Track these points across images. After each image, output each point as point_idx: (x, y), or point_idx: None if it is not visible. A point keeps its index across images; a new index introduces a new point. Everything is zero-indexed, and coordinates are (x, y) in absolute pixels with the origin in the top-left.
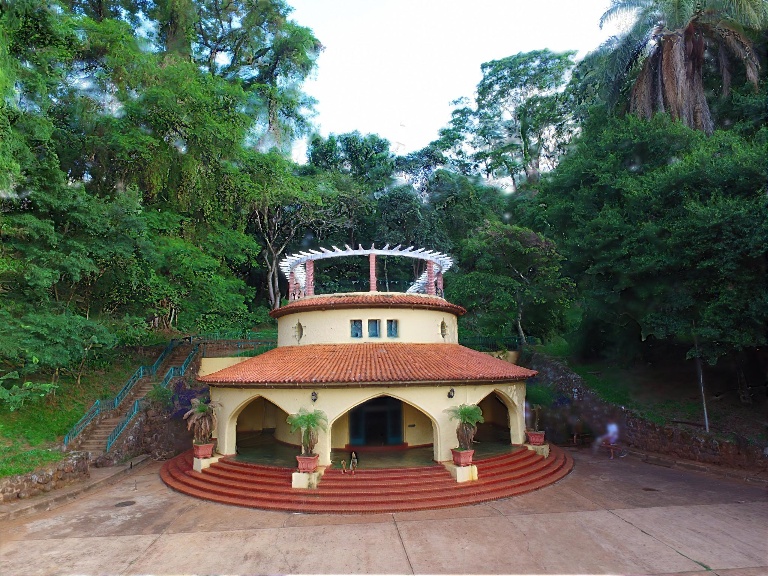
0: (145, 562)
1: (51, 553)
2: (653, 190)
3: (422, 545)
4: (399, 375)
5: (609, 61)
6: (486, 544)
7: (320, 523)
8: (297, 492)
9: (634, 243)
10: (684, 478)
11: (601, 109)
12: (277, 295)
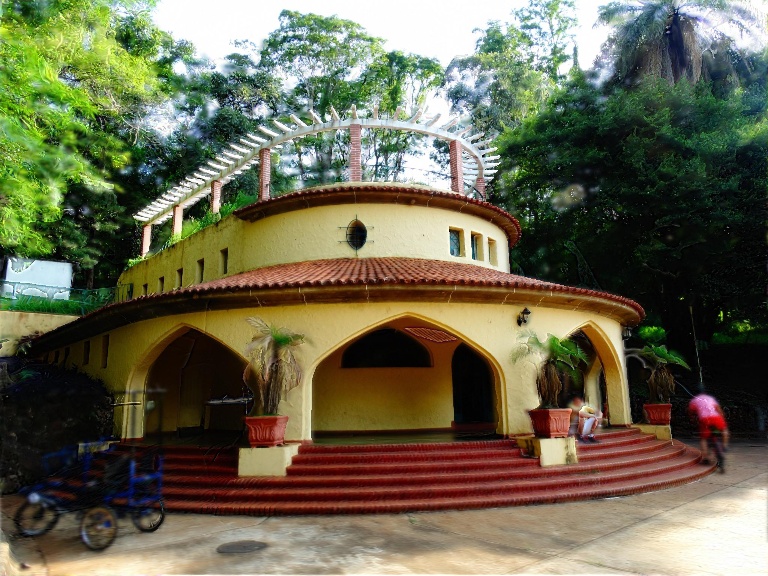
0: None
1: None
2: (732, 147)
3: None
4: None
5: (647, 19)
6: None
7: (682, 499)
8: (567, 469)
9: (717, 196)
10: (733, 441)
11: (590, 73)
12: None
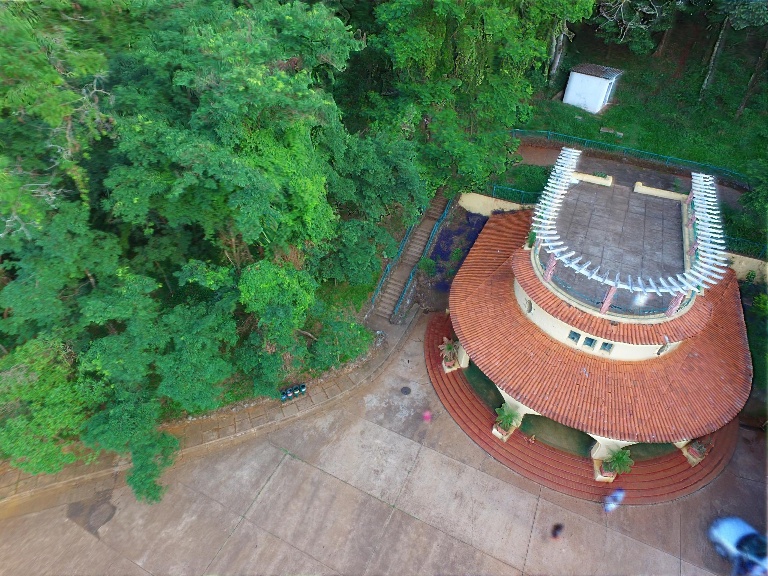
0: (414, 475)
1: (378, 442)
2: None
3: (542, 533)
4: (580, 423)
5: None
6: (576, 553)
7: (499, 476)
8: (493, 440)
9: None
10: None
11: None
12: (558, 52)
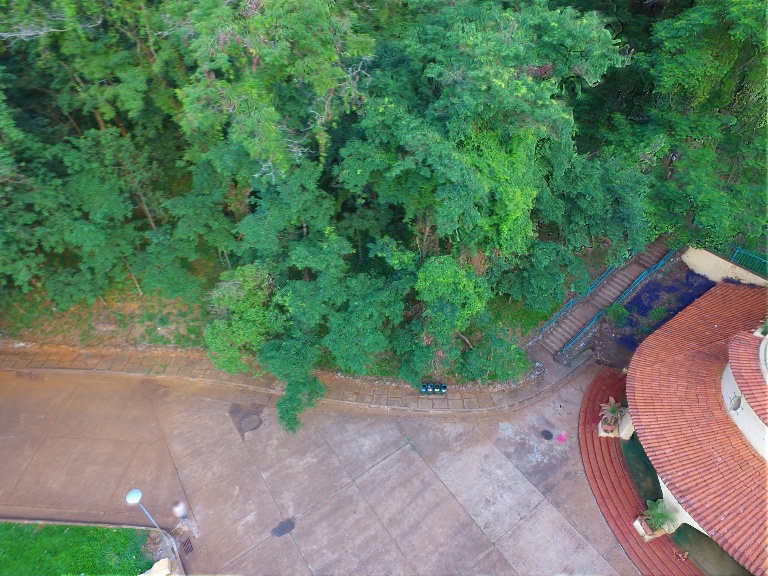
0: (526, 524)
1: (499, 473)
2: None
3: None
4: (760, 569)
5: None
6: None
7: (624, 575)
8: (632, 533)
9: None
10: None
11: None
12: None
